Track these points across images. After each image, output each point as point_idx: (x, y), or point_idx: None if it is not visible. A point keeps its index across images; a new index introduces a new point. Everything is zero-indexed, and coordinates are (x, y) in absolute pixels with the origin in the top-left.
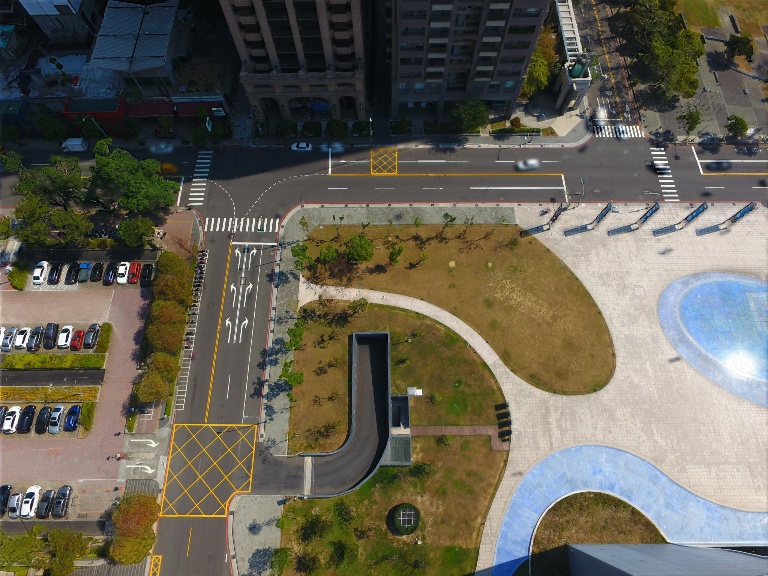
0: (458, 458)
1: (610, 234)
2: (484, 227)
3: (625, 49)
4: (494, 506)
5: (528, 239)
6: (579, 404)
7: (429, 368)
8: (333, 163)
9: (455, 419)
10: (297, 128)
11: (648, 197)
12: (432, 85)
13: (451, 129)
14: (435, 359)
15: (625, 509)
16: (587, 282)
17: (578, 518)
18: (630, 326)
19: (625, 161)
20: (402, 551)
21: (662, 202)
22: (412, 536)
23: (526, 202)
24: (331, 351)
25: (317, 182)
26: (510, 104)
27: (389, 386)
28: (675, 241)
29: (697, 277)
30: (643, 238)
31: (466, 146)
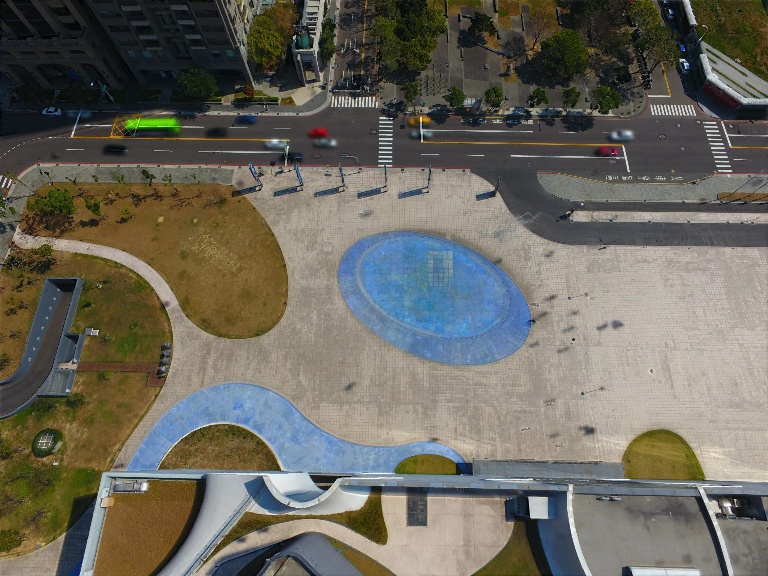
0: (114, 391)
1: (317, 195)
2: (200, 187)
3: None
4: (134, 434)
5: (238, 198)
6: (239, 347)
7: (111, 311)
8: (78, 127)
9: (121, 357)
10: (54, 95)
11: (363, 162)
12: (159, 53)
13: (195, 97)
14: (119, 304)
15: (252, 440)
16: (281, 238)
17: (207, 447)
18: (309, 278)
19: (352, 129)
20: (38, 471)
21: (375, 167)
22: (52, 458)
23: (247, 165)
24: (26, 294)
25: (58, 144)
26: (244, 74)
27: (65, 326)
28: (376, 203)
29: (386, 236)
30: (347, 199)
31: (206, 113)
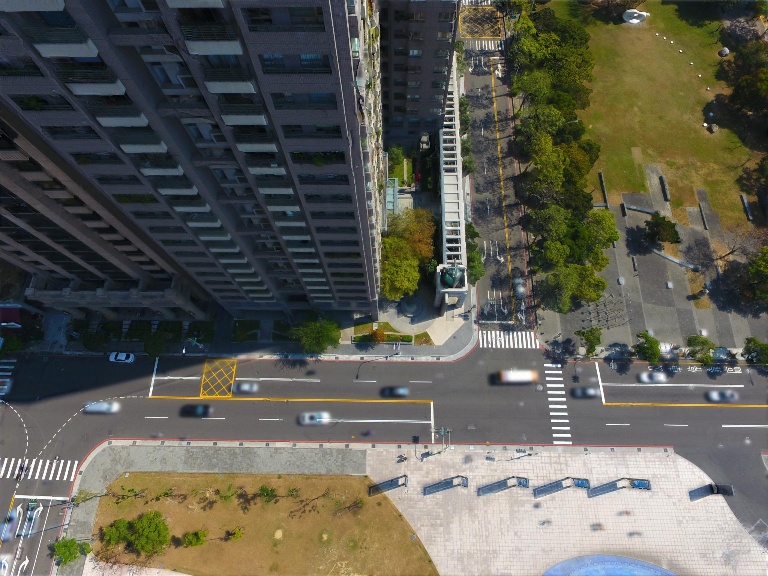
0: None
1: (480, 493)
2: (325, 479)
3: (529, 222)
4: None
5: (377, 499)
6: None
7: None
8: (157, 380)
9: None
10: (122, 329)
11: (533, 437)
12: None
13: None
14: None
15: None
16: (442, 566)
17: None
18: None
19: (511, 383)
20: None
21: (550, 445)
22: None
23: (382, 442)
24: None
25: (133, 407)
26: (371, 312)
27: None
28: (560, 505)
29: (581, 562)
30: (520, 500)
31: (321, 358)
